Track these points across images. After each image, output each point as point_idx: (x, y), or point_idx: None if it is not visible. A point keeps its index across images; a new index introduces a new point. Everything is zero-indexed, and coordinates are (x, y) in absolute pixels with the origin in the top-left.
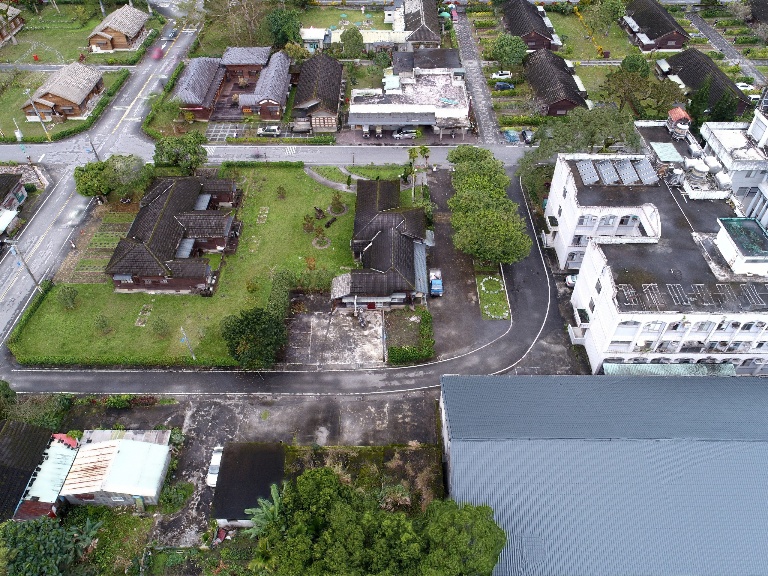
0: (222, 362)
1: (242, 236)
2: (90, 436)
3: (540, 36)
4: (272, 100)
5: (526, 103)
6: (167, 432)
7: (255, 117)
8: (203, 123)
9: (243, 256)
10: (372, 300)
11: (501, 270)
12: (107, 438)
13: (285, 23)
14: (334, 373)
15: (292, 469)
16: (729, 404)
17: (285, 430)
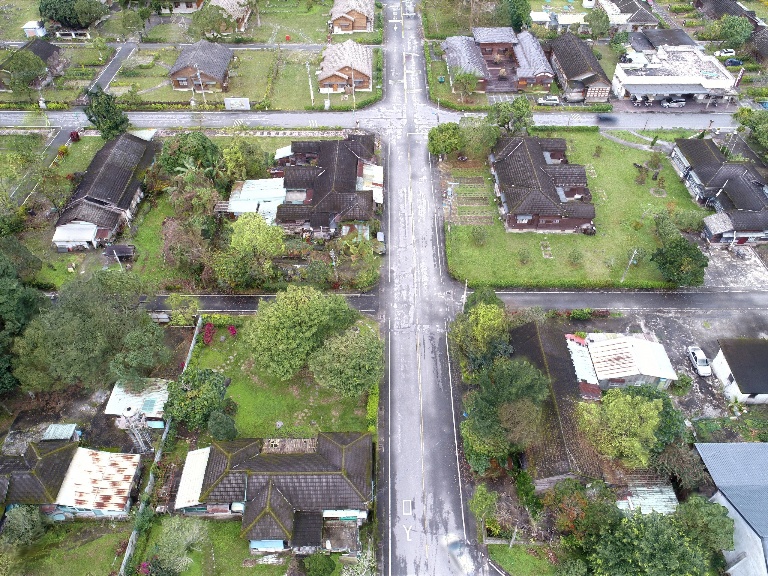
0: (646, 284)
1: (585, 187)
2: (589, 337)
3: (748, 18)
4: (549, 73)
5: (766, 77)
6: (651, 334)
7: (527, 89)
8: (481, 94)
9: (598, 203)
10: (748, 235)
11: None
12: (605, 338)
13: (520, 6)
14: (742, 293)
15: None
16: None
17: (732, 335)
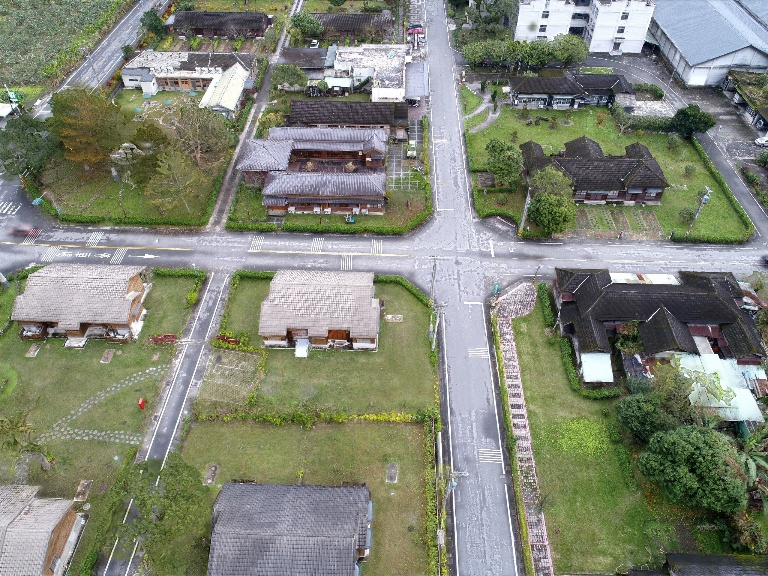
0: None
1: None
2: None
3: None
4: None
5: None
6: None
7: None
8: None
9: None
10: None
11: (571, 67)
12: None
13: None
14: None
15: (767, 106)
16: (677, 7)
17: None
